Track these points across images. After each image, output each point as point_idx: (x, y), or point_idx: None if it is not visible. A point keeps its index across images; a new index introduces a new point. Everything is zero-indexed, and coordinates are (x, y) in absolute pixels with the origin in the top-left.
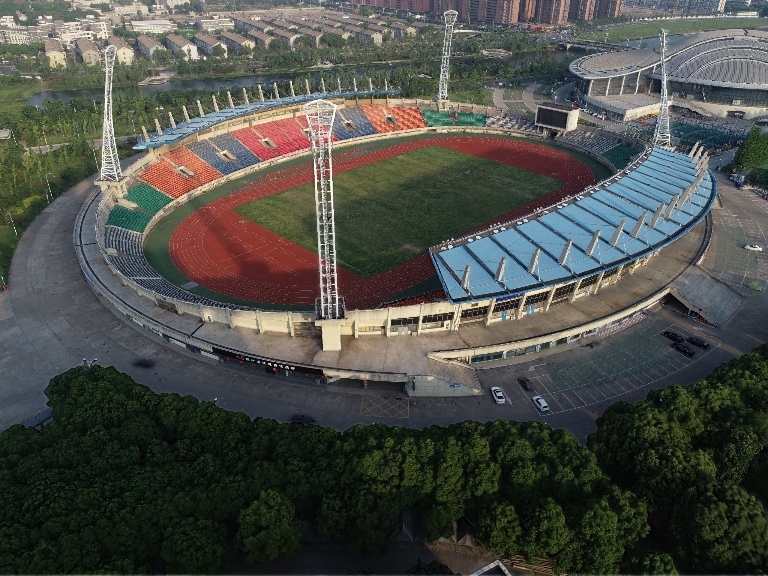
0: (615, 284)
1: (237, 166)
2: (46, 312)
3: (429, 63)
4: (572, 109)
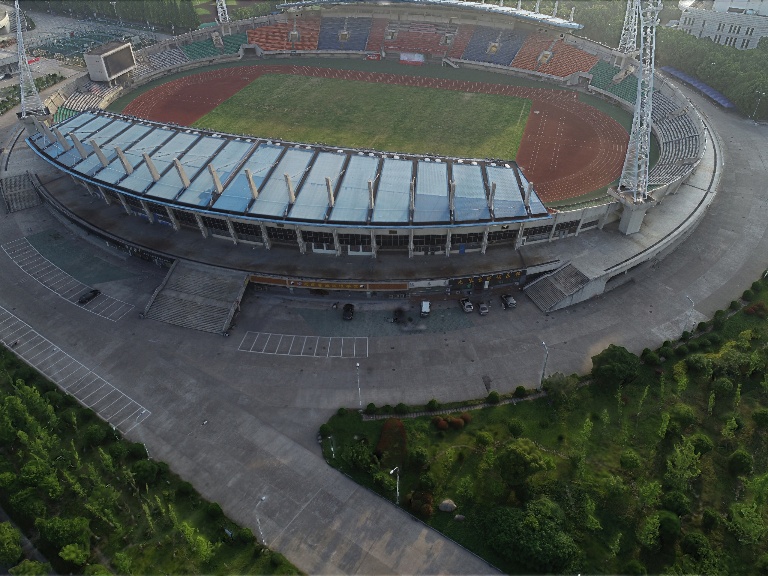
0: None
1: None
2: (763, 178)
3: None
4: (122, 41)
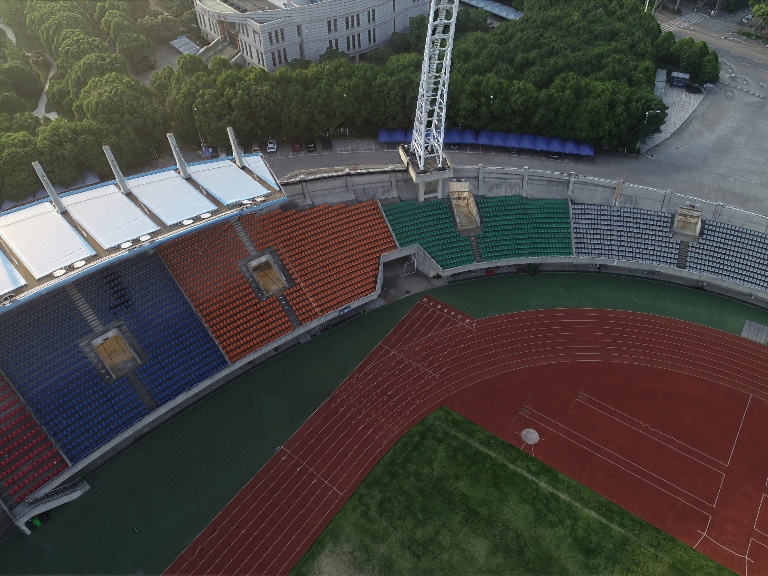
0: None
1: None
2: None
3: None
4: None
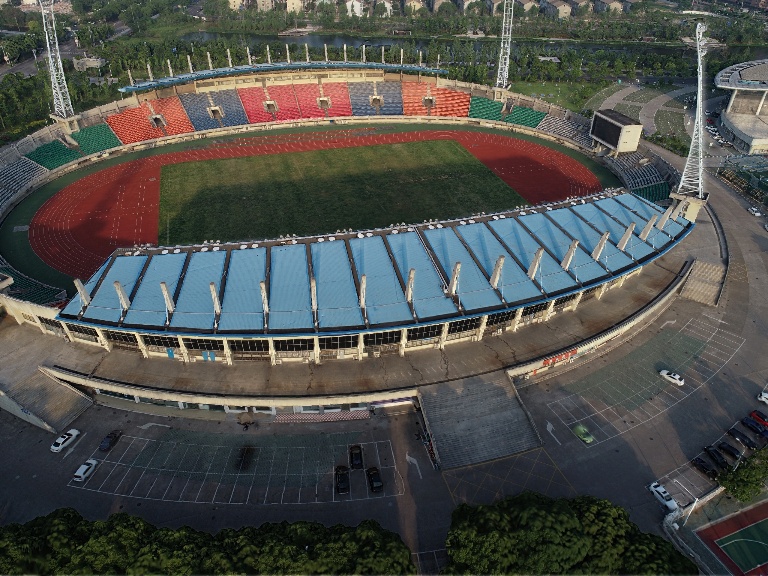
0: (361, 360)
1: (218, 124)
2: None
3: (586, 45)
4: (630, 123)
